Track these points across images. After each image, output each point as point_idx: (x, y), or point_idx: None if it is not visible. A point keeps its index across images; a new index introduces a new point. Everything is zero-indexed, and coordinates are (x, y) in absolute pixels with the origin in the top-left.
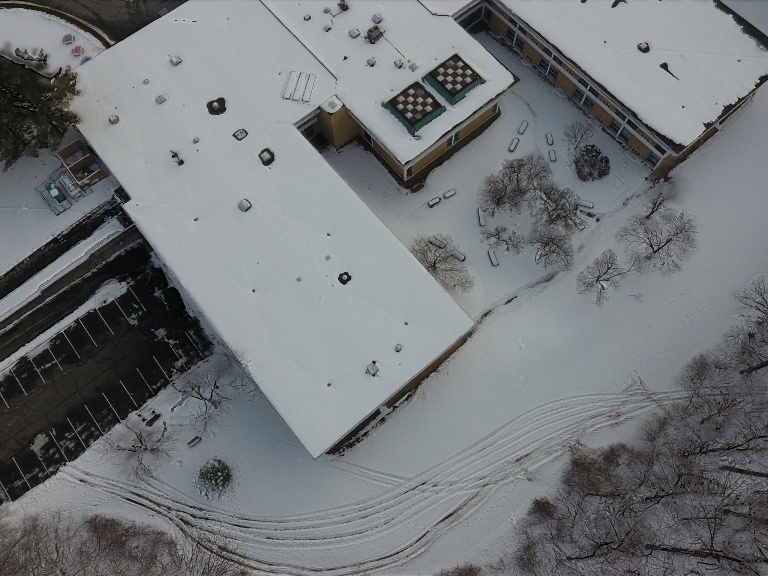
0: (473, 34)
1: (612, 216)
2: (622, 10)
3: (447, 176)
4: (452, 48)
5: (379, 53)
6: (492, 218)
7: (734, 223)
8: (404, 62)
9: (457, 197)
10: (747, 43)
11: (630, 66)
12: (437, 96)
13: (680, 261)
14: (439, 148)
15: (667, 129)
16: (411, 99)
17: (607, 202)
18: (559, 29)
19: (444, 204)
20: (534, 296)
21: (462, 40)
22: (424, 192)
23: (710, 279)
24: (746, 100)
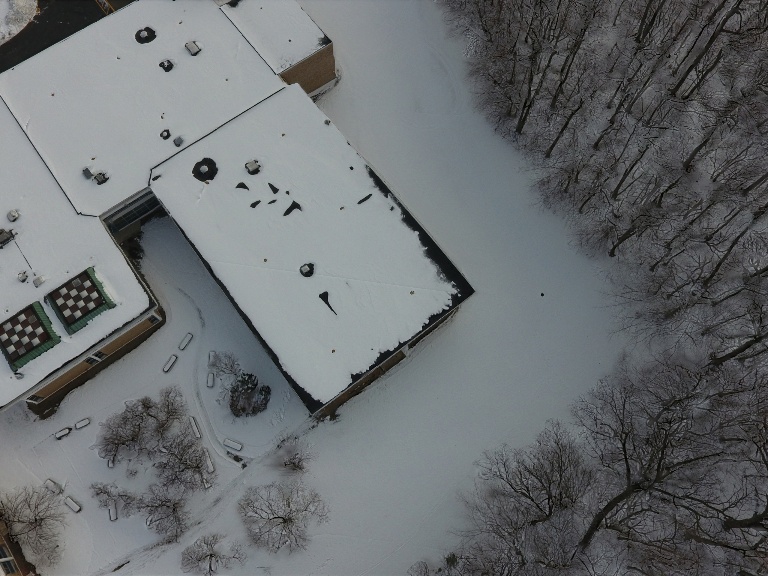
0: (158, 218)
1: (261, 462)
2: (294, 219)
3: (85, 400)
4: (89, 259)
5: (3, 261)
6: (113, 465)
7: (400, 476)
8: (29, 275)
9: (91, 428)
10: (426, 270)
11: (285, 294)
12: (55, 322)
13: (303, 541)
14: (74, 370)
15: (307, 380)
16: (19, 328)
17: (259, 444)
18: (216, 241)
19: (74, 436)
20: (149, 562)
21: (103, 249)
22: (55, 419)
23: (359, 546)
24: (445, 319)
